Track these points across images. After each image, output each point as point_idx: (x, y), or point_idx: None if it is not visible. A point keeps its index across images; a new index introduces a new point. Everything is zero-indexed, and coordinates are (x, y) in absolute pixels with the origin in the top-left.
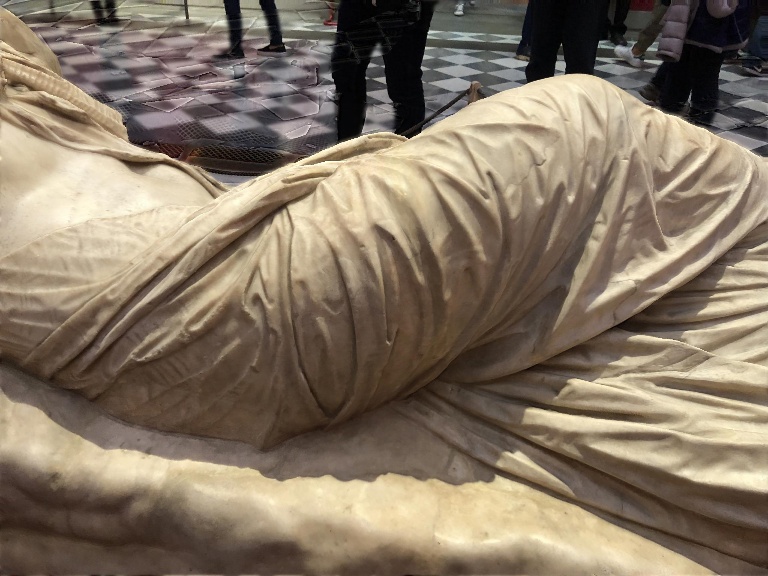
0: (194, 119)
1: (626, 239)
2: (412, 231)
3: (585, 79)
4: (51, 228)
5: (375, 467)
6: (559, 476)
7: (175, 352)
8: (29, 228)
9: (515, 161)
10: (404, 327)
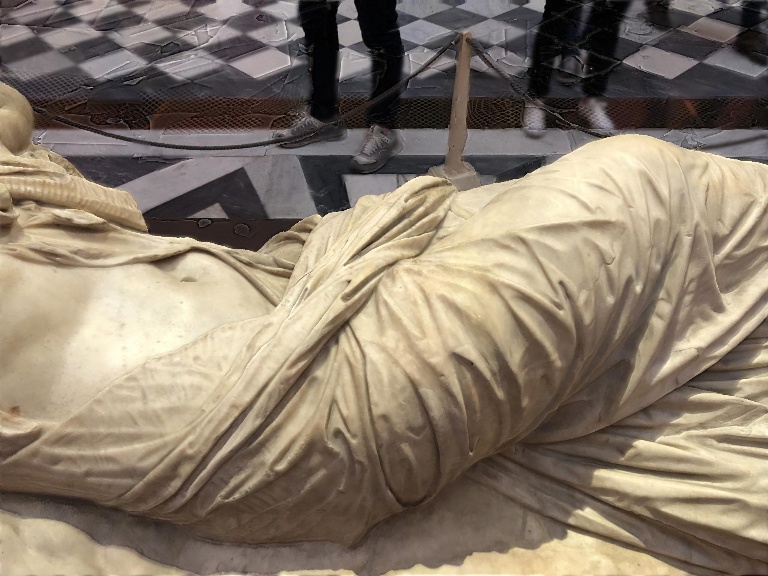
0: (159, 91)
1: (688, 310)
2: (490, 353)
3: (642, 147)
4: (108, 378)
5: (460, 548)
6: (629, 530)
7: (261, 488)
8: (85, 381)
9: (585, 264)
10: (484, 435)
